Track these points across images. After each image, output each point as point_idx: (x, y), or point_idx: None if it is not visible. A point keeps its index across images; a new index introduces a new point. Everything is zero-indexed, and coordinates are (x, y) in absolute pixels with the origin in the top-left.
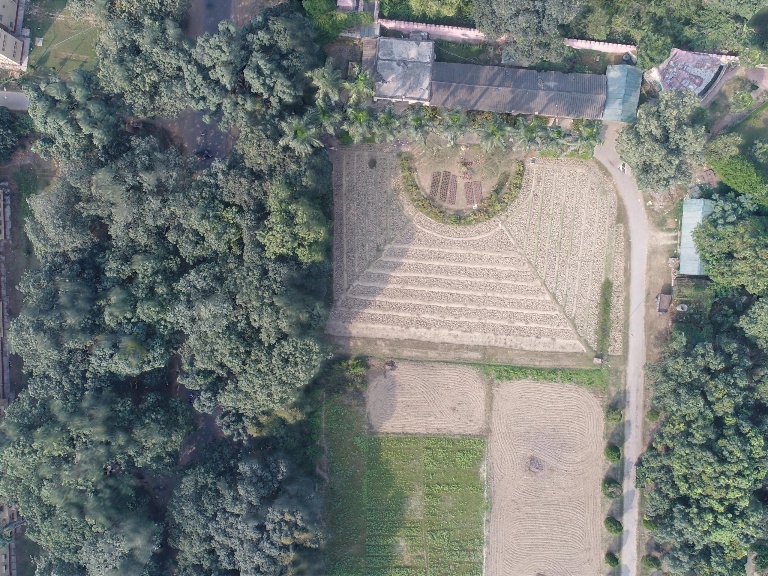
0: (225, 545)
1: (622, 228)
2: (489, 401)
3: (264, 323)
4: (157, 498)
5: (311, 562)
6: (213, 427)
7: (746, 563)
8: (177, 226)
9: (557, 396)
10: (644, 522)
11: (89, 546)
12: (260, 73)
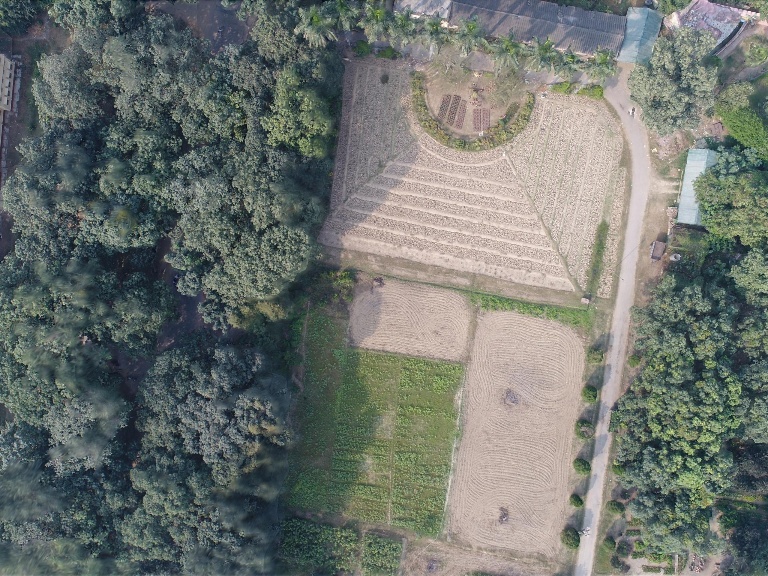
0: (191, 429)
1: (625, 172)
2: (472, 329)
3: (257, 206)
4: (130, 379)
5: (275, 459)
6: (194, 316)
7: (710, 522)
8: (183, 107)
9: (541, 332)
10: (613, 467)
11: (55, 410)
12: None
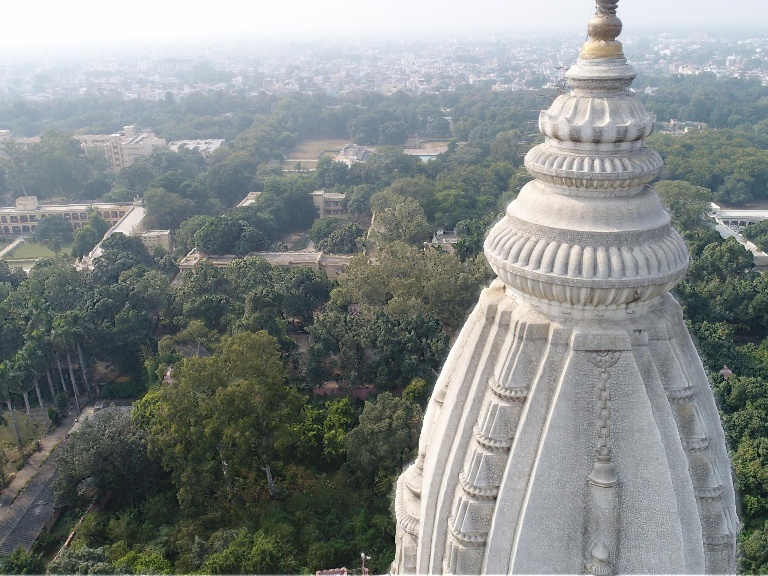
0: None
1: None
2: None
3: None
4: None
5: None
6: None
7: None
8: None
9: None
10: None
11: None
12: None
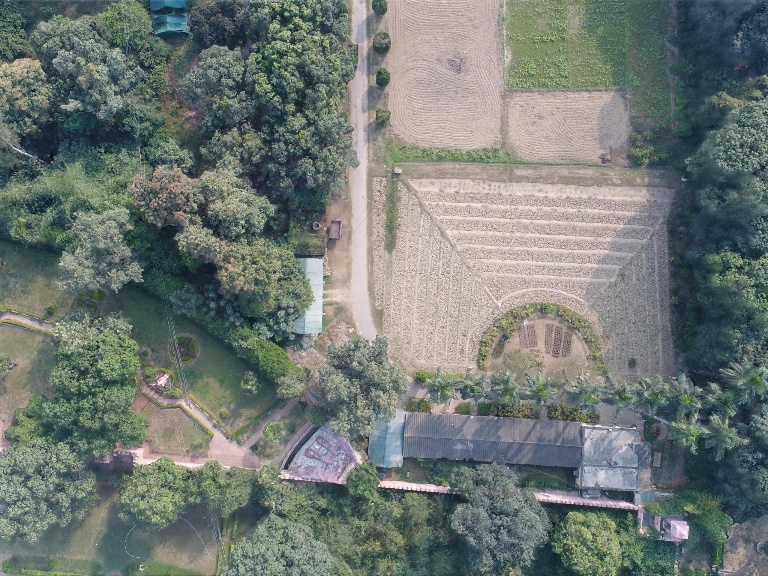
0: None
1: (378, 305)
2: (505, 127)
3: None
4: None
5: None
6: None
7: None
8: None
9: (437, 134)
10: None
11: None
12: None
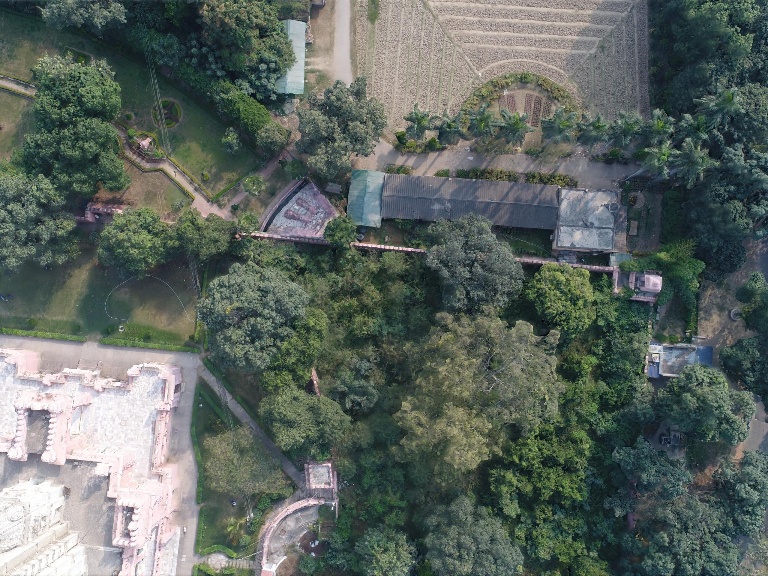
0: None
1: (360, 73)
2: None
3: None
4: None
5: None
6: None
7: None
8: None
9: None
10: None
11: None
12: (765, 168)
